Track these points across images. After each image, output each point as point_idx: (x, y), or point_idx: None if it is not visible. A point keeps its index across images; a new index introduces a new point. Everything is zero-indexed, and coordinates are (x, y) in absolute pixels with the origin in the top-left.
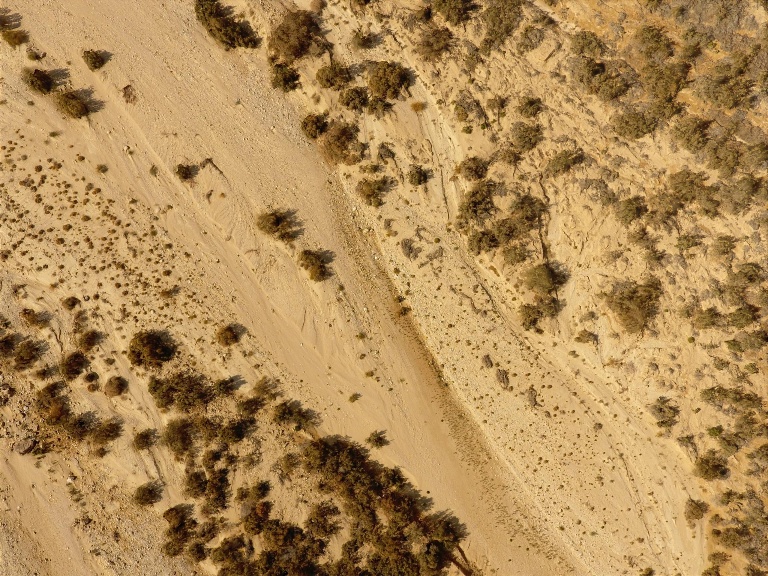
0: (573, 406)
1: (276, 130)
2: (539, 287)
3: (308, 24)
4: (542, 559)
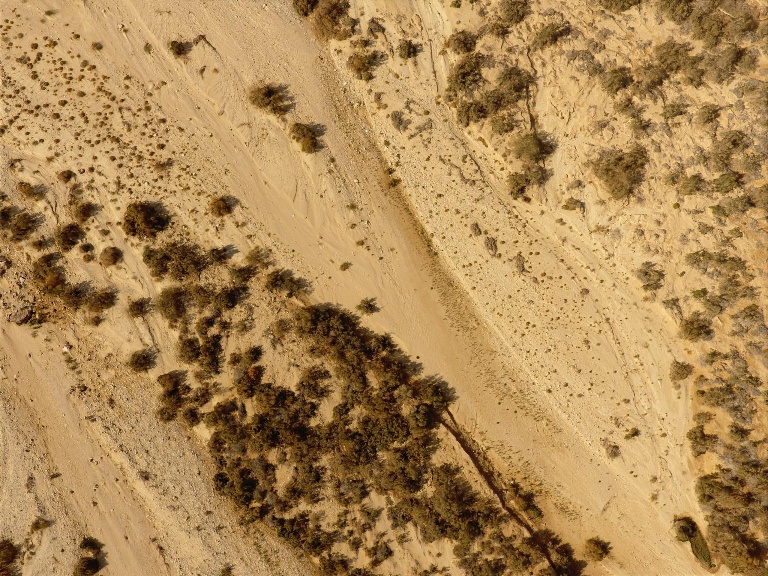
0: (560, 272)
1: (268, 8)
2: (527, 155)
3: None
4: (530, 421)
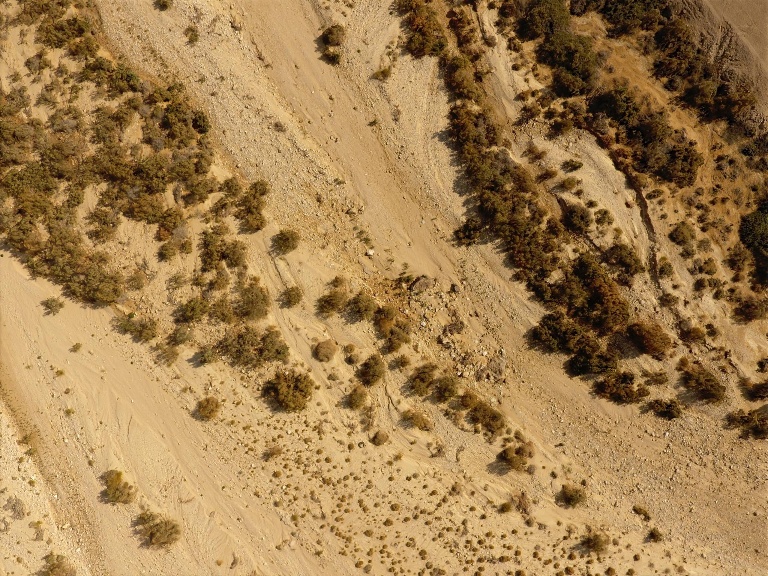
0: None
1: None
2: None
3: None
4: None
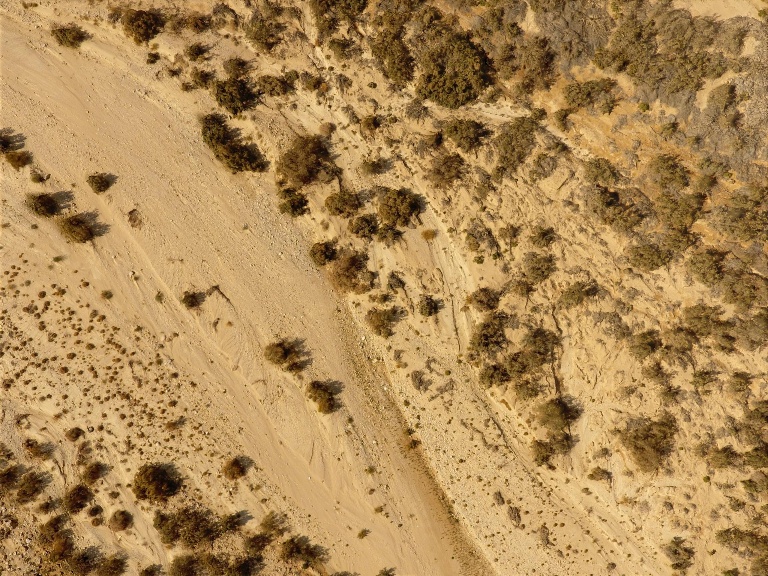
0: (586, 545)
1: (284, 256)
2: (552, 424)
3: (317, 150)
4: None
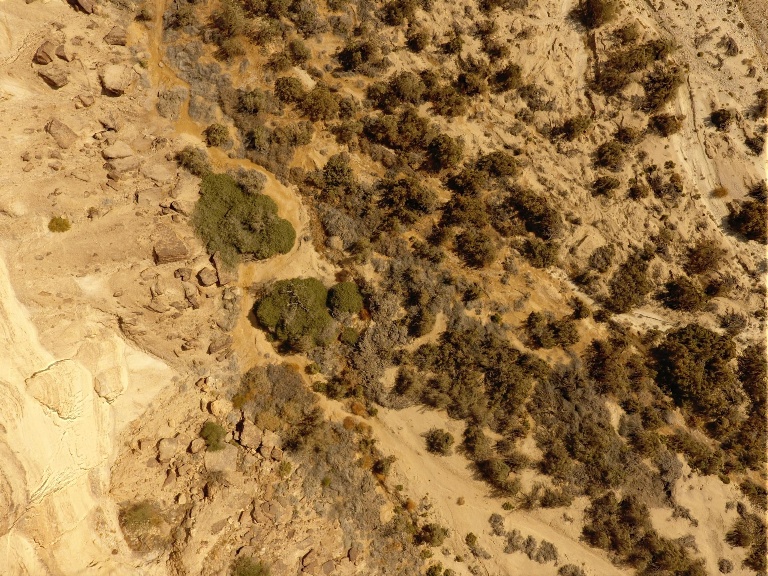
0: None
1: None
2: (602, 3)
3: None
4: None
